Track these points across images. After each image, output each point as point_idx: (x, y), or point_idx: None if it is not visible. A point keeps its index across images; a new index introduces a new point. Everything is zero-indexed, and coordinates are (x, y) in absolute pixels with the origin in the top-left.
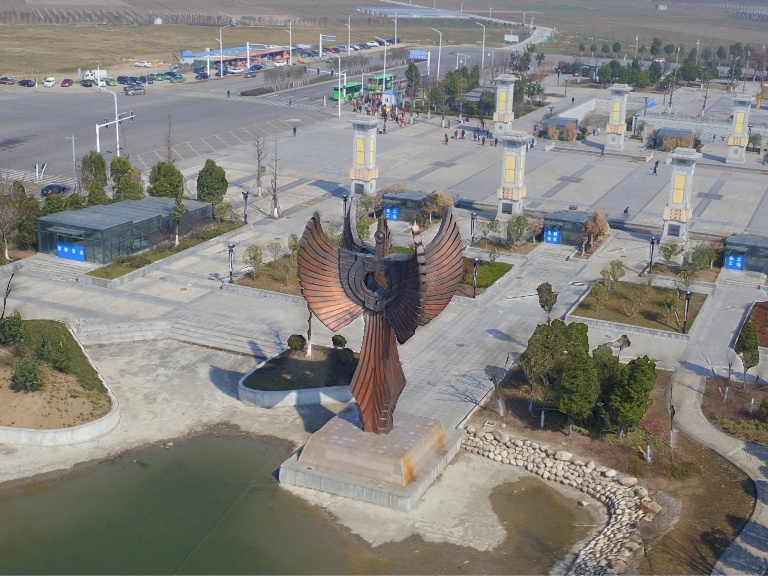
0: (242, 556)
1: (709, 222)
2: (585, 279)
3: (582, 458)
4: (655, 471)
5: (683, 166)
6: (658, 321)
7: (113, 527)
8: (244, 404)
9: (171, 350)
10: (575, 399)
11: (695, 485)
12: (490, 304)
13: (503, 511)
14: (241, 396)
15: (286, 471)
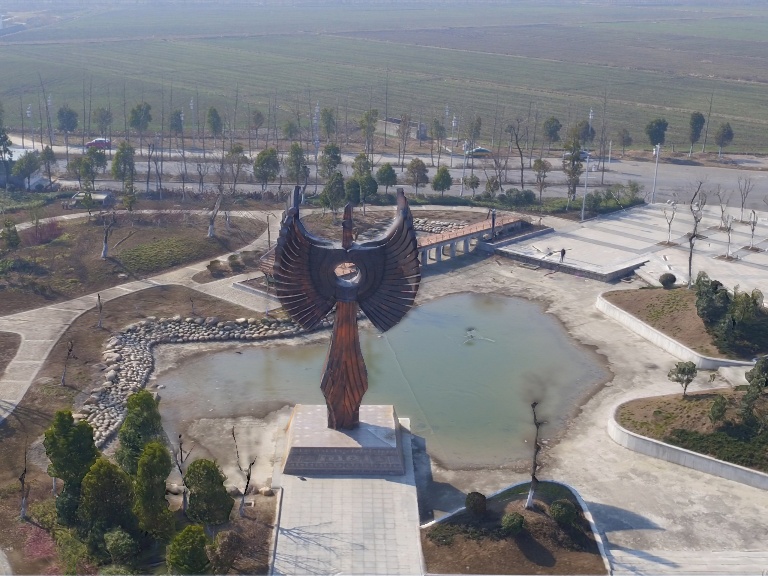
0: (374, 388)
1: None
2: None
3: None
4: None
5: None
6: None
7: (482, 385)
8: None
9: (749, 537)
10: None
11: (6, 481)
12: None
13: (199, 450)
14: None
15: None
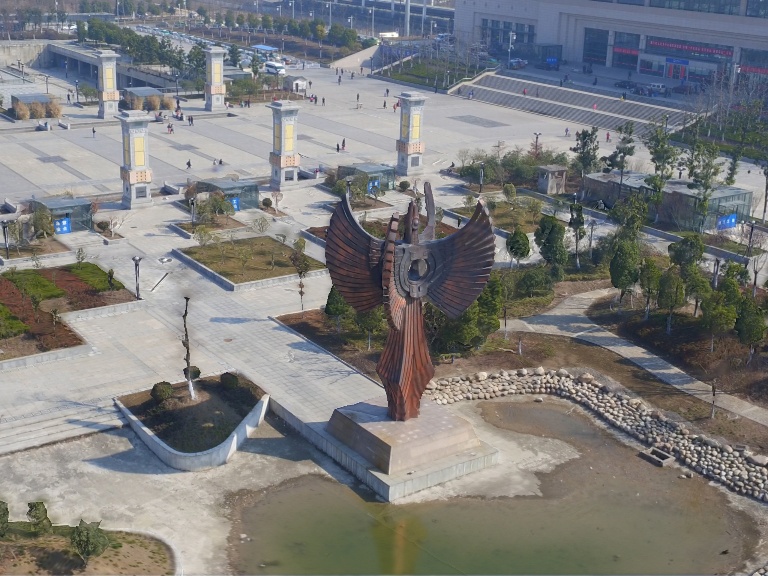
0: (508, 559)
1: (111, 181)
2: (160, 255)
3: (489, 372)
4: (537, 358)
5: (140, 128)
6: (293, 266)
7: None
8: (200, 472)
9: (6, 470)
10: (473, 326)
11: (565, 355)
12: (153, 301)
13: (525, 430)
14: (190, 466)
15: (396, 487)
